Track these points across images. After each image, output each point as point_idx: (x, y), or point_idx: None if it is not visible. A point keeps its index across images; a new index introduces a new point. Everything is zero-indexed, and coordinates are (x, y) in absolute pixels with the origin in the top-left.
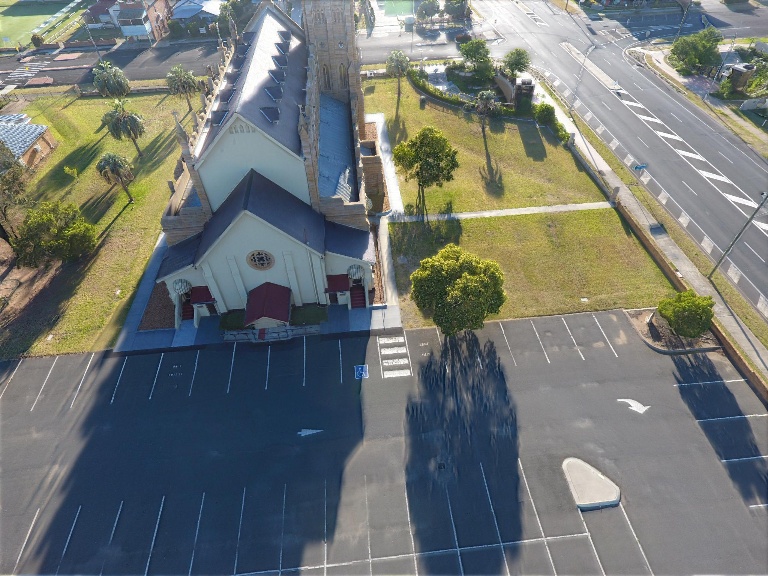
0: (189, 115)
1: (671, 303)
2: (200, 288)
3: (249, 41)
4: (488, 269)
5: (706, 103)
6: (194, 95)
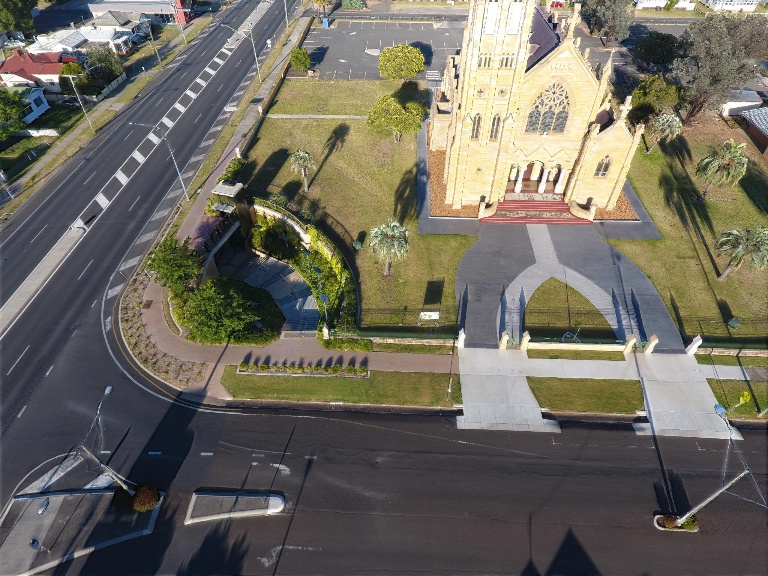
0: (710, 264)
1: None
2: None
3: None
4: None
5: (18, 195)
6: (760, 324)
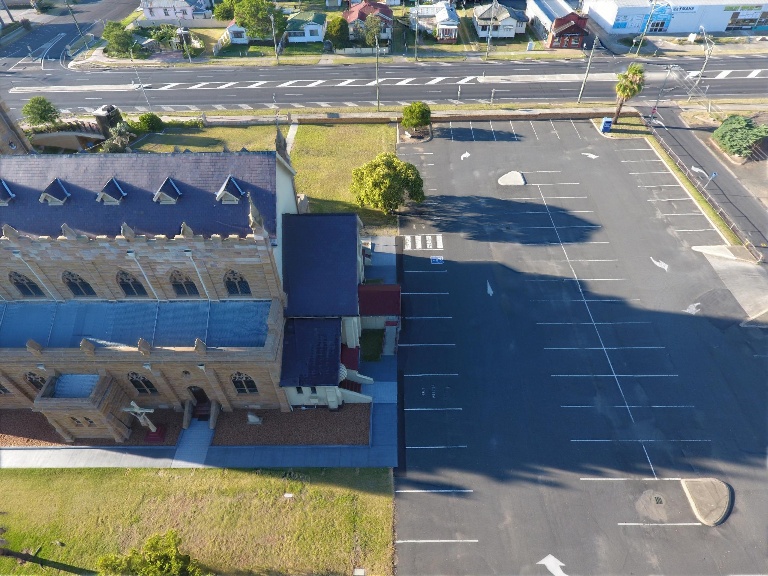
0: None
1: (411, 117)
2: None
3: None
4: (388, 156)
5: (195, 63)
6: None
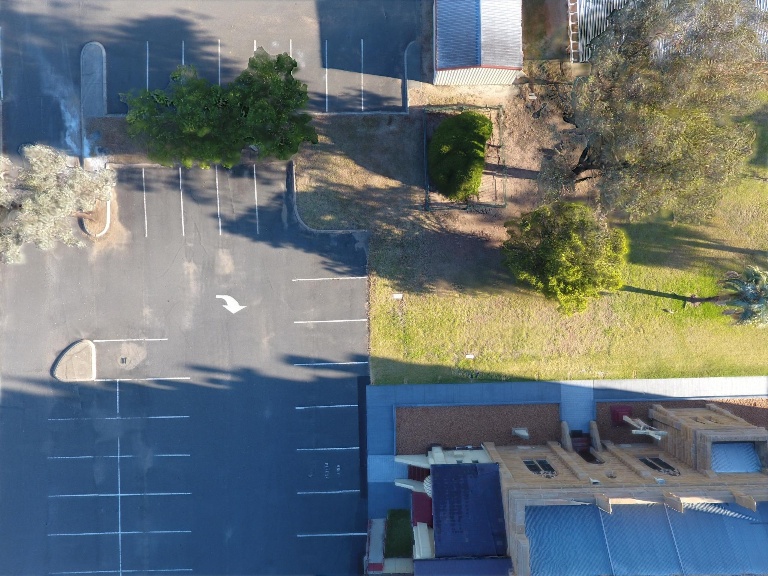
0: None
1: None
2: None
3: None
4: None
5: None
6: None
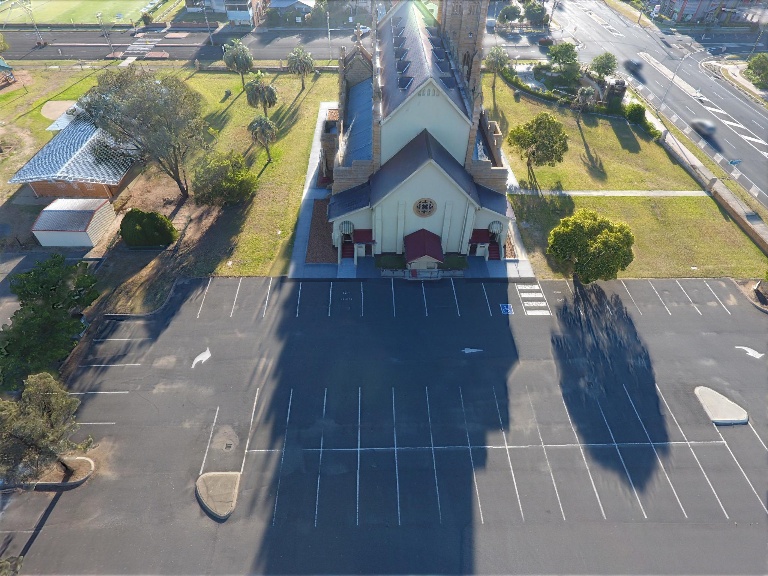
0: (303, 93)
1: None
2: (361, 231)
3: (397, 25)
4: (623, 229)
5: None
6: (303, 76)
